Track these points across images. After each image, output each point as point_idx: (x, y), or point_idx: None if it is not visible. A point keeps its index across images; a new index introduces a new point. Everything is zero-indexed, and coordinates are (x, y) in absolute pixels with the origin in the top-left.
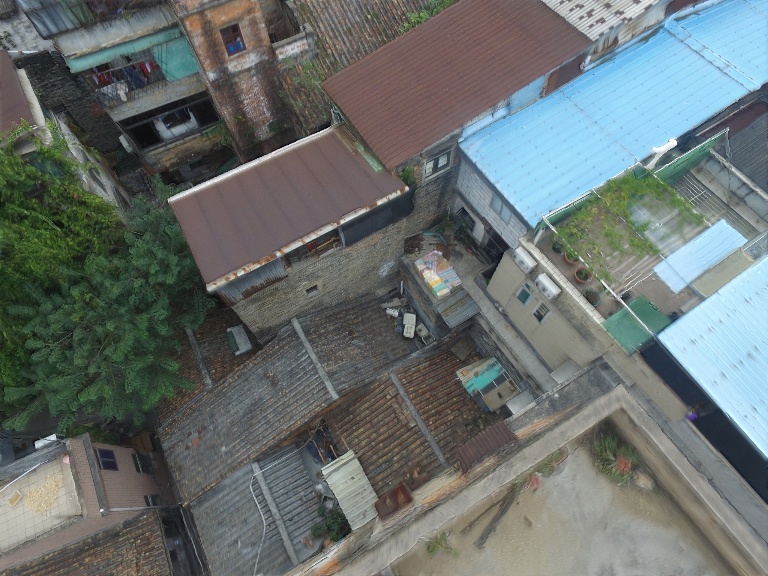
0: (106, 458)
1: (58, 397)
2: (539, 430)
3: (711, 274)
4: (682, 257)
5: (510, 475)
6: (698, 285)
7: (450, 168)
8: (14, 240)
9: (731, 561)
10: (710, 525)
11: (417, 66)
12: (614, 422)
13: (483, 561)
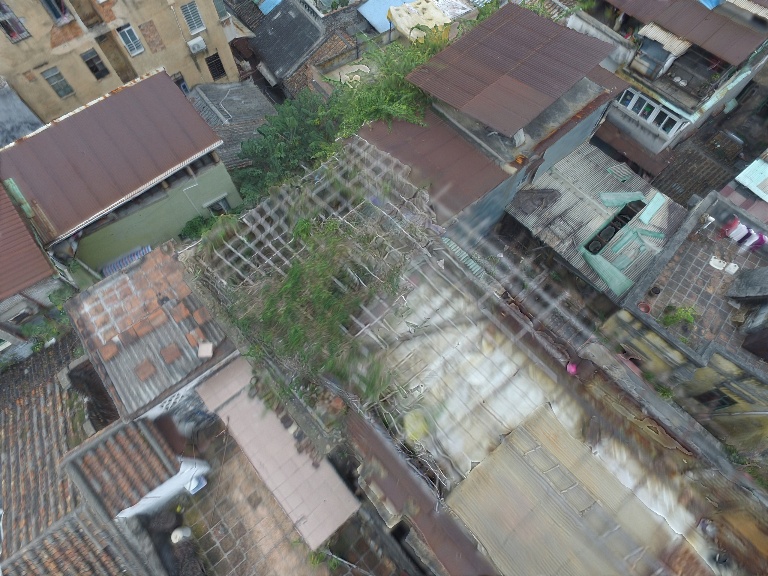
0: None
1: None
2: None
3: None
4: None
5: None
6: None
7: None
8: None
9: None
10: None
11: None
12: None
13: None
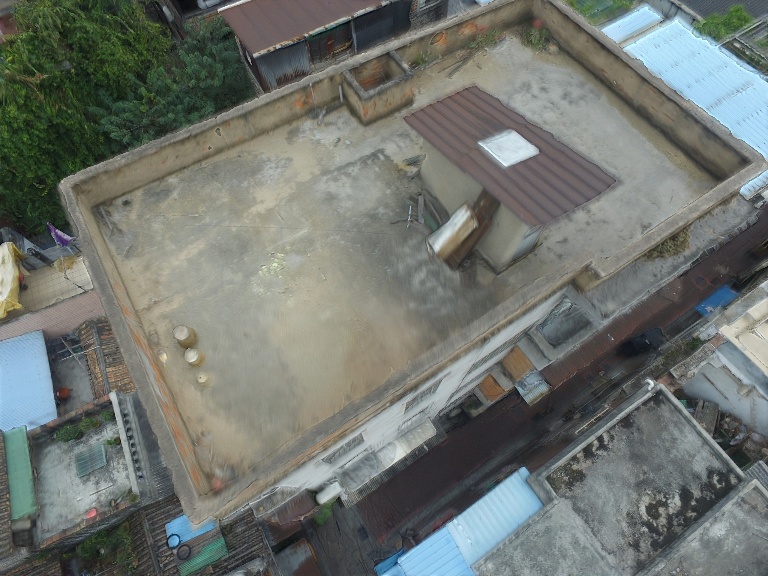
0: None
1: None
2: None
3: (634, 39)
4: (613, 29)
5: (466, 16)
6: (623, 45)
7: (440, 2)
8: (100, 37)
9: (599, 73)
10: (587, 50)
11: None
12: (535, 19)
13: (451, 83)
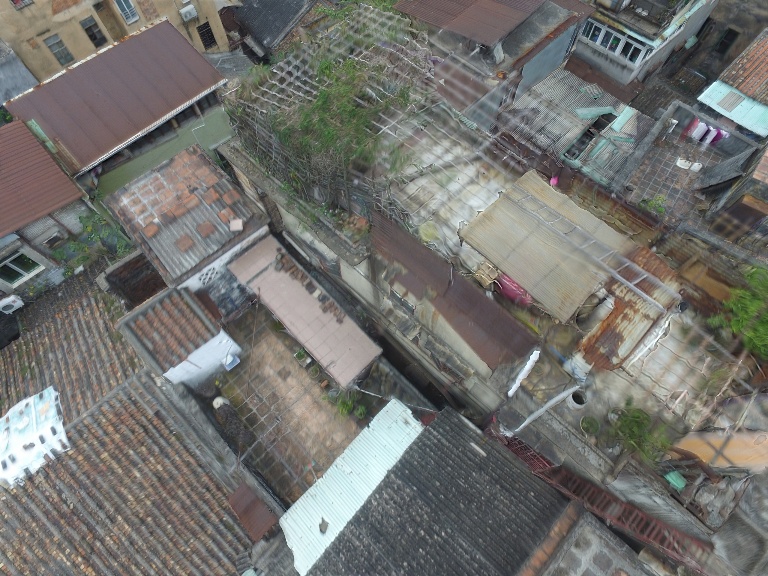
0: None
1: None
2: None
3: None
4: None
5: None
6: None
7: None
8: None
9: None
10: None
11: None
12: None
13: None
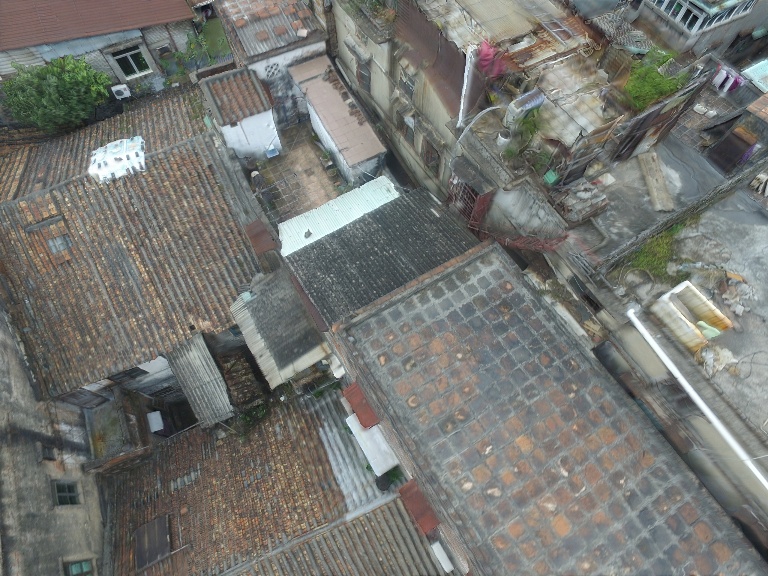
0: None
1: None
2: None
3: None
4: None
5: None
6: None
7: None
8: None
9: None
10: None
11: (103, 7)
12: None
13: None
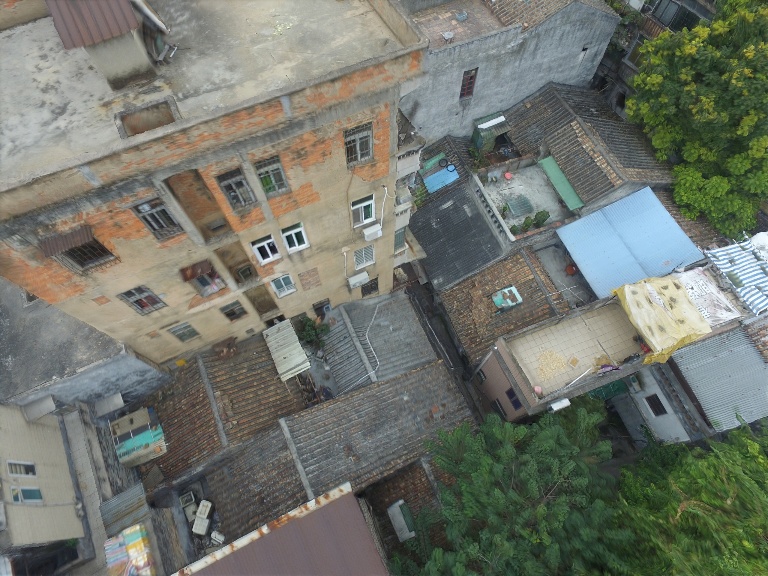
0: (515, 400)
1: (548, 432)
2: (6, 226)
3: None
4: None
5: (24, 174)
6: None
7: None
8: None
9: None
10: None
11: None
12: None
13: None
